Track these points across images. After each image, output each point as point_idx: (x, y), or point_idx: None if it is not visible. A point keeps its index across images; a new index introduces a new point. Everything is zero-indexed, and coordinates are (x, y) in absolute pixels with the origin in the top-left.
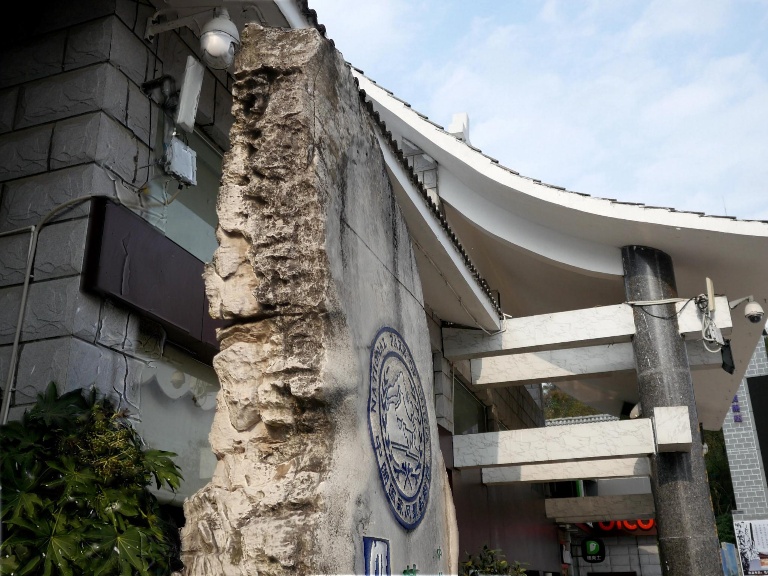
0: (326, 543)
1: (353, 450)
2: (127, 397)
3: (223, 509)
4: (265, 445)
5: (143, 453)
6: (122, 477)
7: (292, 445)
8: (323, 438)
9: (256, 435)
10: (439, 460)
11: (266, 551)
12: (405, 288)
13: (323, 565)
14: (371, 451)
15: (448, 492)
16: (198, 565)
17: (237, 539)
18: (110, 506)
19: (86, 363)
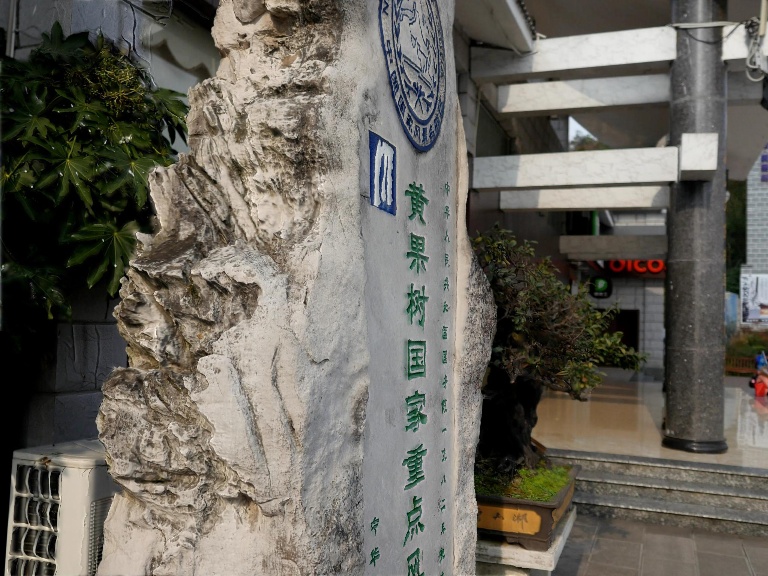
0: (330, 122)
1: (362, 46)
2: (137, 50)
3: (228, 96)
4: (271, 39)
5: (154, 93)
6: (134, 115)
7: (298, 38)
8: (330, 28)
9: (261, 28)
10: (453, 102)
11: (270, 123)
12: None
13: (327, 141)
14: (381, 52)
15: (460, 136)
16: (204, 145)
17: (242, 122)
18: (124, 140)
19: (91, 5)
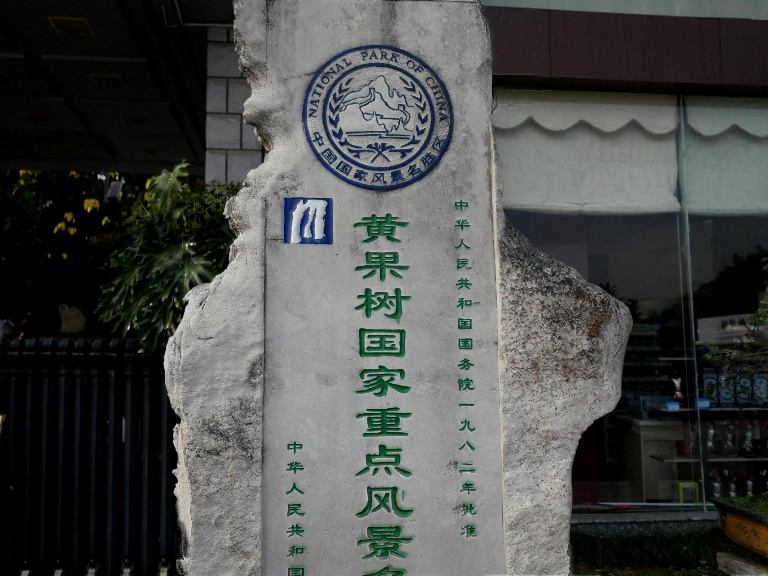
0: (243, 204)
1: (287, 147)
2: None
3: None
4: None
5: None
6: None
7: None
8: None
9: None
10: (477, 131)
11: None
12: (413, 1)
13: (239, 216)
14: (306, 144)
15: (492, 155)
16: None
17: None
18: None
19: None
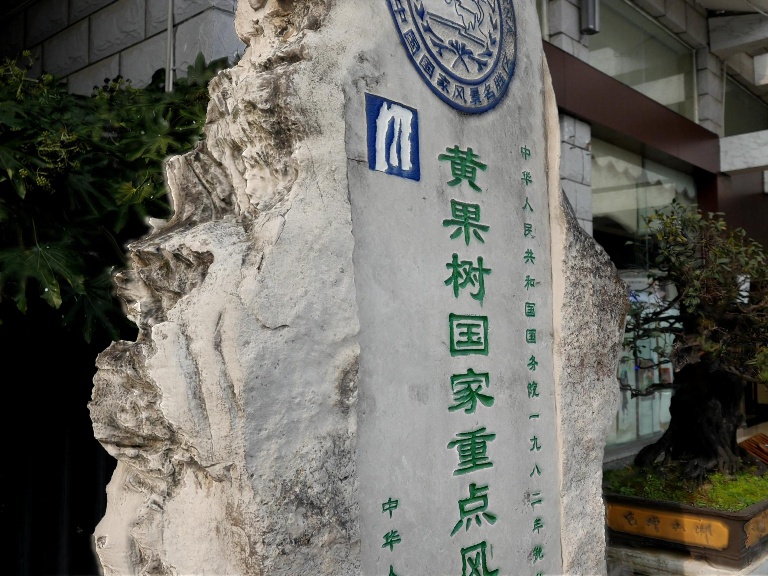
0: (304, 87)
1: (357, 8)
2: None
3: (235, 80)
4: (278, 19)
5: None
6: None
7: (298, 12)
8: None
9: (269, 10)
10: (534, 58)
11: (245, 97)
12: None
13: (299, 107)
14: (385, 12)
15: (547, 94)
16: (212, 130)
17: None
18: None
19: (228, 32)
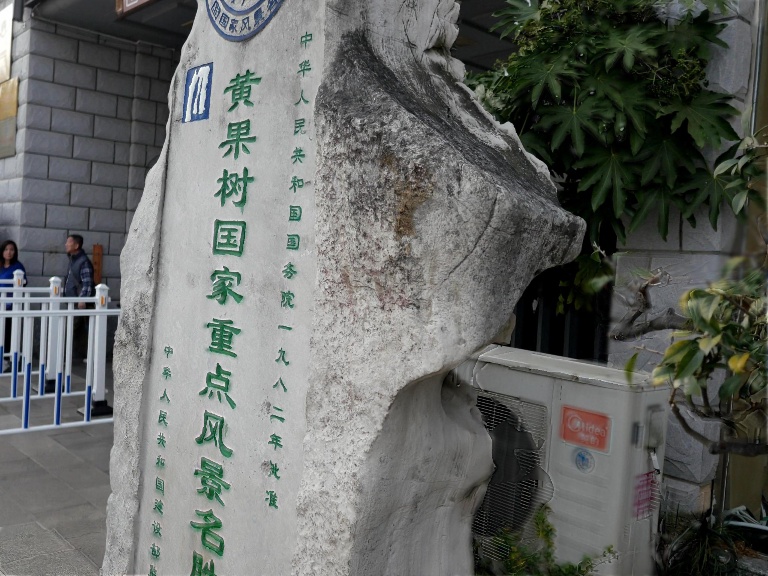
0: None
1: None
2: None
3: None
4: None
5: None
6: (549, 43)
7: None
8: None
9: None
10: None
11: None
12: None
13: None
14: None
15: None
16: None
17: None
18: None
19: None
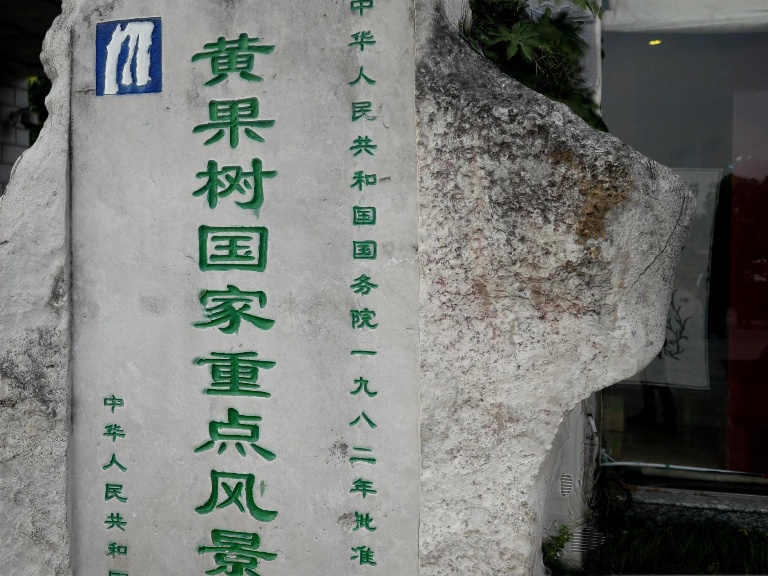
0: None
1: None
2: None
3: None
4: None
5: None
6: None
7: None
8: None
9: None
10: None
11: None
12: None
13: (46, 58)
14: None
15: None
16: None
17: None
18: None
19: None
